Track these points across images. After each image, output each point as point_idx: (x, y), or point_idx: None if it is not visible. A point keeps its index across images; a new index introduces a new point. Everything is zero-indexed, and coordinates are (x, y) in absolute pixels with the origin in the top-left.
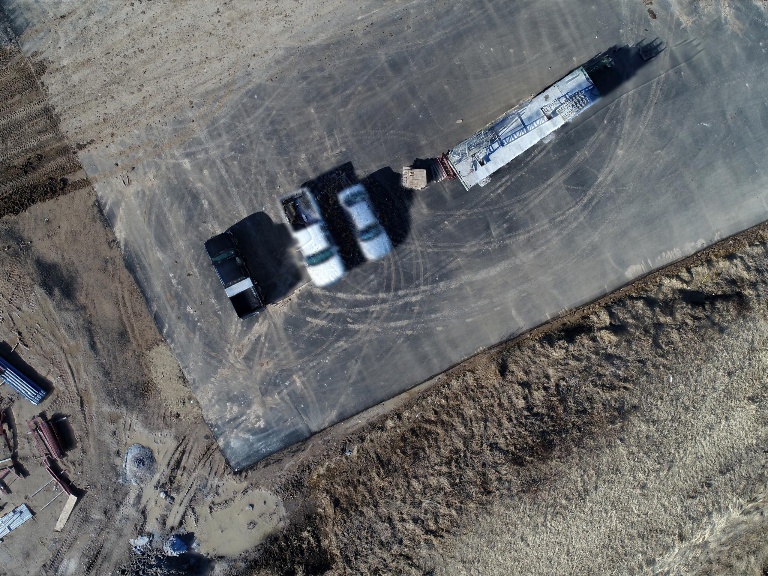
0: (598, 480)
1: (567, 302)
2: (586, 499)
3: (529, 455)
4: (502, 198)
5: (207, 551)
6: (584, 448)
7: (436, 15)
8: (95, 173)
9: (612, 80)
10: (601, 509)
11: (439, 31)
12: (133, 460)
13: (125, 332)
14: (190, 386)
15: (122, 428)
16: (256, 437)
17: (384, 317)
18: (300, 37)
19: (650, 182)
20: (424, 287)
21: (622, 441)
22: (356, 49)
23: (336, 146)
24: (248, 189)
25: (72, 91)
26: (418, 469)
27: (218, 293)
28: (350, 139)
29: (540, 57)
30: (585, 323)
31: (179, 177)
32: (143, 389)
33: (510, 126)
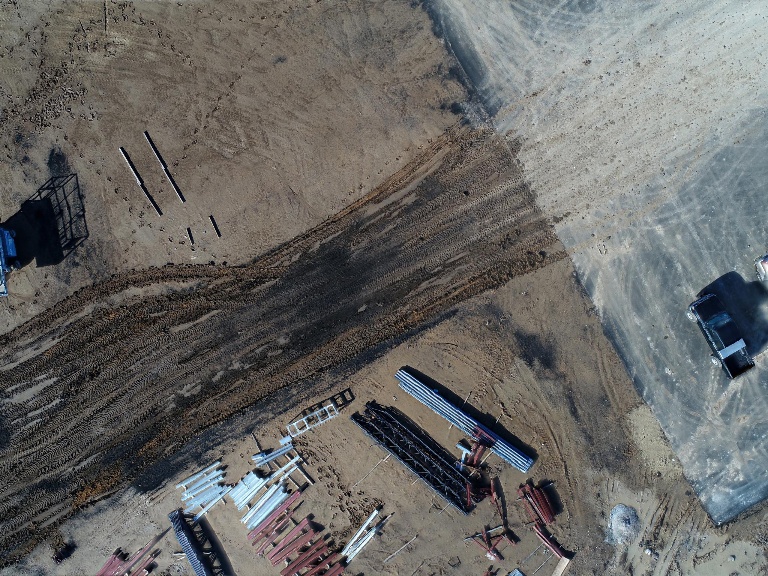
0: None
1: None
2: None
3: None
4: None
5: None
6: None
7: None
8: (572, 245)
9: None
10: None
11: None
12: (620, 520)
13: (605, 397)
14: (671, 445)
15: (605, 490)
16: (736, 490)
17: None
18: (765, 98)
19: None
20: None
21: None
22: None
23: None
24: (720, 250)
25: (547, 166)
26: None
27: (694, 353)
28: None
29: None
30: None
31: (653, 243)
32: (625, 451)
33: None
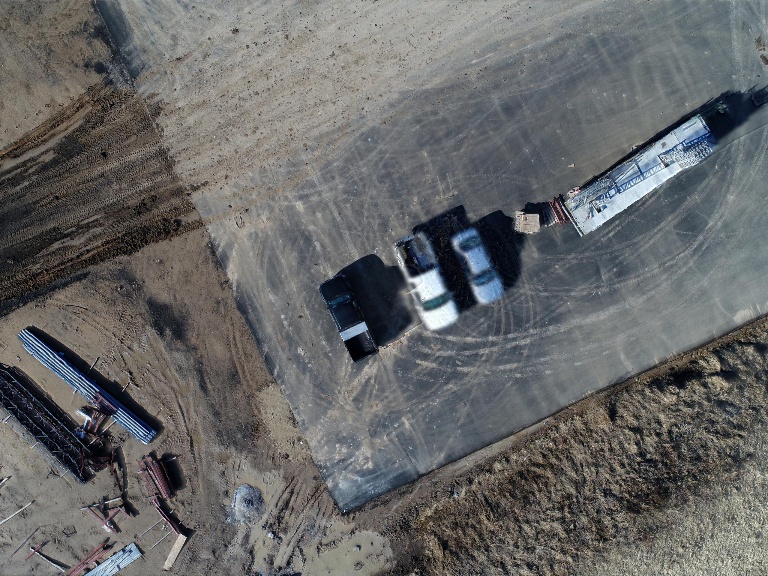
0: (714, 529)
1: (675, 347)
2: (702, 548)
3: (645, 503)
4: (612, 242)
5: None
6: (700, 496)
7: (550, 60)
8: (209, 215)
9: (724, 126)
10: (717, 558)
11: (552, 76)
12: (242, 500)
13: (236, 373)
14: (300, 427)
15: (231, 468)
16: (364, 479)
17: (493, 360)
18: (414, 81)
19: (760, 228)
20: (533, 331)
21: (738, 490)
22: (469, 93)
23: (448, 189)
24: (360, 232)
25: (187, 133)
26: (529, 514)
27: (329, 335)
28: (462, 183)
29: (652, 102)
30: (694, 368)
31: (292, 219)
32: (253, 430)
33: (627, 173)
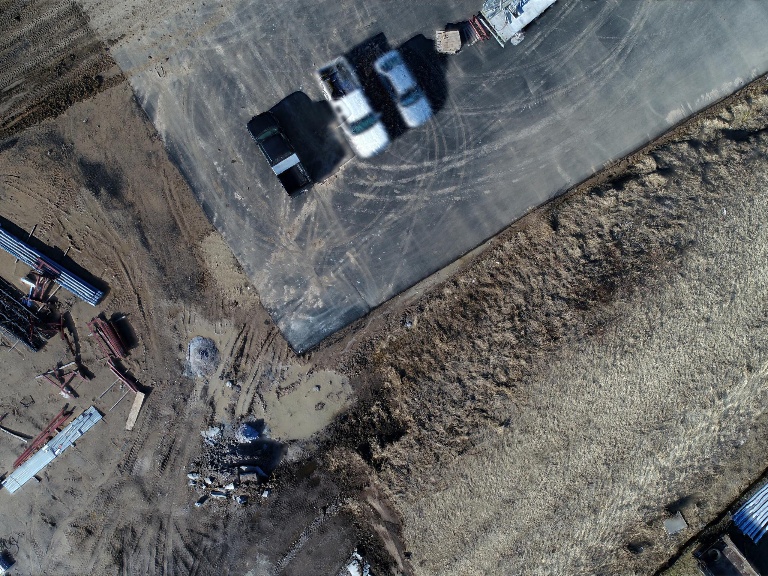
0: (663, 316)
1: (611, 154)
2: (653, 336)
3: (592, 299)
4: (537, 55)
5: (278, 436)
6: (646, 286)
7: None
8: (129, 68)
9: None
10: (669, 344)
11: None
12: (196, 352)
13: (175, 225)
14: (245, 273)
15: (182, 322)
16: (316, 317)
17: (431, 186)
18: None
19: (682, 25)
20: (468, 152)
21: (683, 276)
22: None
23: (367, 18)
24: (283, 70)
25: None
26: (481, 329)
27: (264, 177)
28: (380, 10)
29: None
30: (631, 172)
31: (213, 64)
32: (199, 281)
33: None
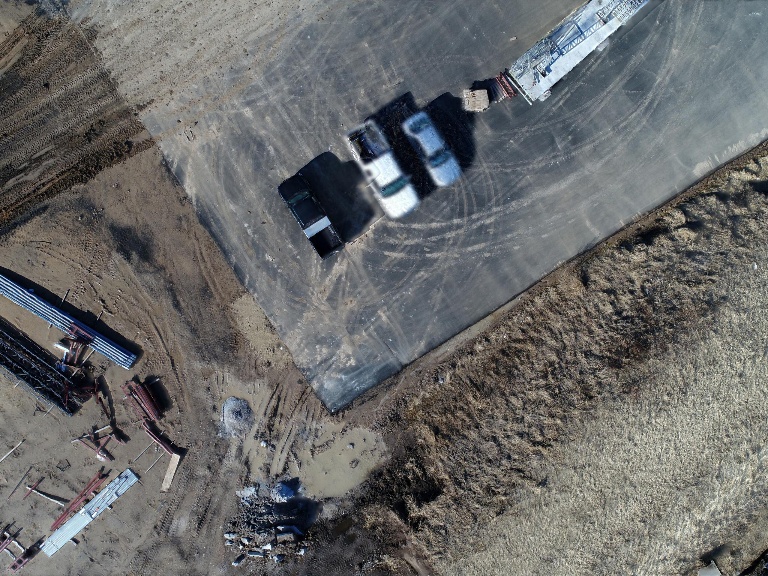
0: (696, 373)
1: (639, 207)
2: (687, 393)
3: (625, 356)
4: (564, 110)
5: (313, 494)
6: (679, 343)
7: None
8: (159, 132)
9: None
10: (703, 401)
11: None
12: (230, 413)
13: (207, 287)
14: (278, 333)
15: (215, 383)
16: (348, 376)
17: (461, 243)
18: None
19: (708, 78)
20: (497, 208)
21: (715, 332)
22: None
23: (394, 78)
24: (312, 131)
25: (126, 53)
26: (514, 386)
27: (294, 238)
28: (407, 69)
29: None
30: (660, 225)
31: (242, 127)
32: (231, 342)
33: (567, 34)
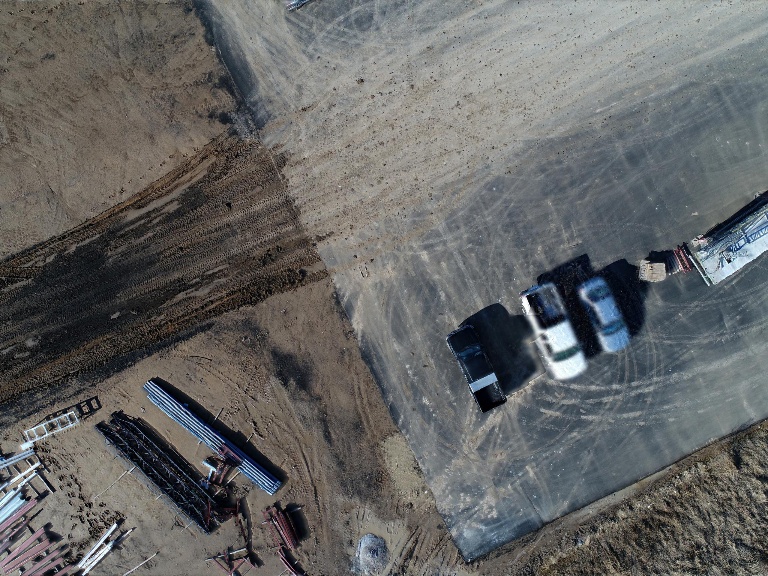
0: None
1: None
2: None
3: None
4: (735, 290)
5: None
6: None
7: (673, 108)
8: (334, 265)
9: None
10: None
11: (676, 124)
12: (367, 550)
13: (360, 423)
14: (424, 477)
15: (355, 518)
16: (489, 527)
17: (617, 408)
18: (539, 130)
19: None
20: (657, 378)
21: None
22: (594, 142)
23: (573, 238)
24: (485, 281)
25: (312, 183)
26: (658, 563)
27: (453, 384)
28: (586, 231)
29: None
30: None
31: (417, 269)
32: (377, 479)
33: (756, 223)
